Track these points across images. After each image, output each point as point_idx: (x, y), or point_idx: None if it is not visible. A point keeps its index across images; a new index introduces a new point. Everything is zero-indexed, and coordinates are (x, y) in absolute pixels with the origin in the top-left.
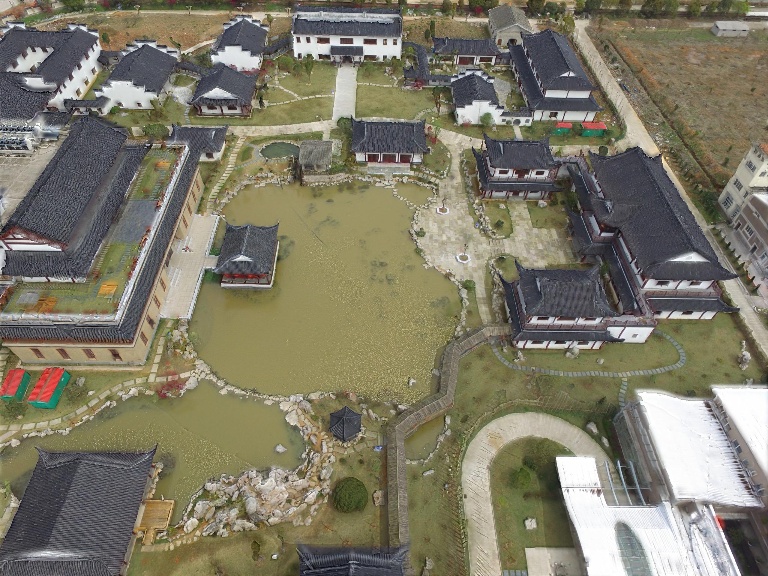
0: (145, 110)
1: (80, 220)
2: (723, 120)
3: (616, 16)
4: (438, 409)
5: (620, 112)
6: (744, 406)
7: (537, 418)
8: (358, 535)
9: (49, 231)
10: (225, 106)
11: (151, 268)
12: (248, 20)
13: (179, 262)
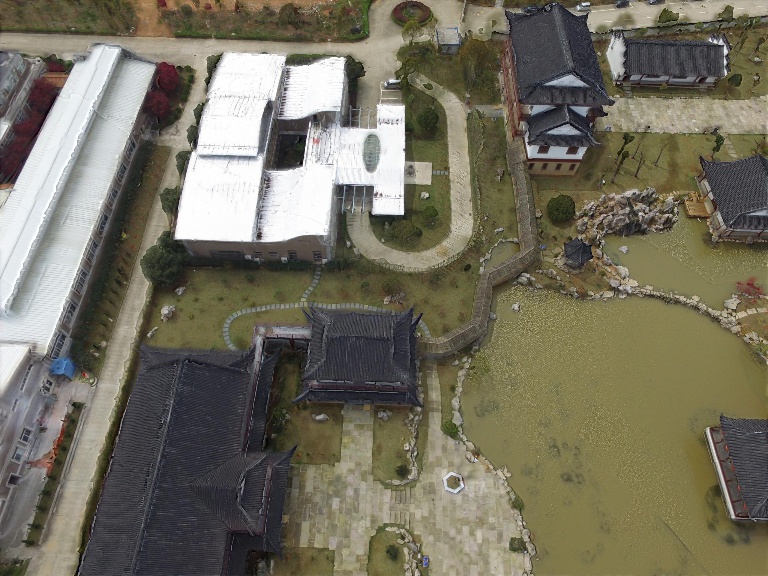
0: None
1: None
2: None
3: None
4: (495, 266)
5: None
6: (236, 221)
7: None
8: (549, 194)
9: None
10: None
11: None
12: None
13: None
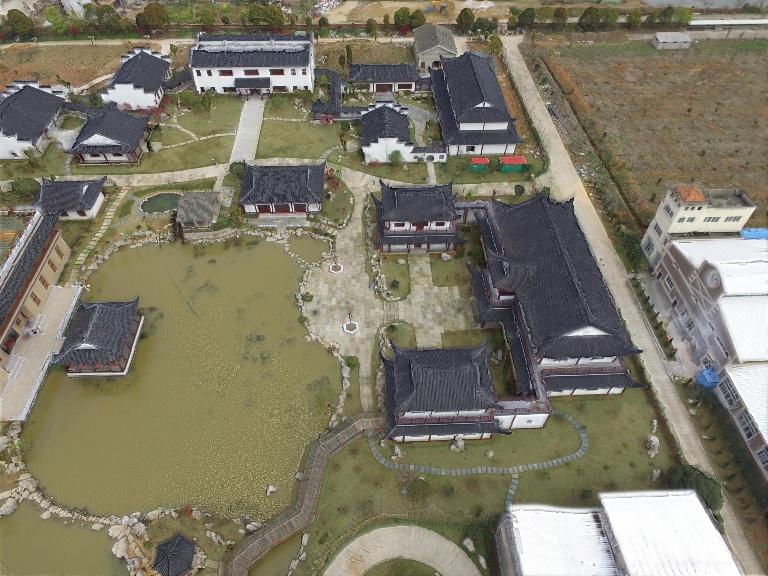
0: (22, 160)
1: None
2: (655, 147)
3: (552, 30)
4: (290, 531)
5: (543, 143)
6: (634, 524)
7: (408, 533)
8: None
9: None
10: (108, 153)
11: None
12: (147, 52)
13: (25, 347)
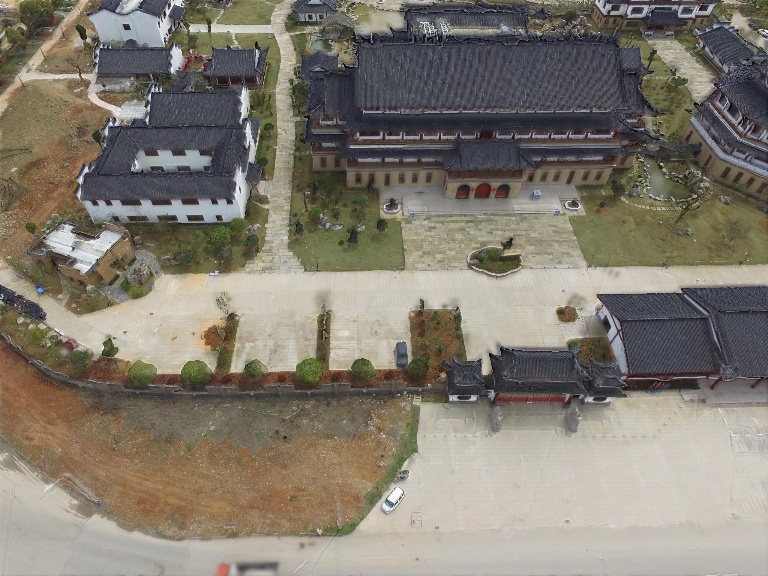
0: (249, 113)
1: None
2: None
3: None
4: None
5: None
6: None
7: None
8: None
9: None
10: None
11: None
12: None
13: None
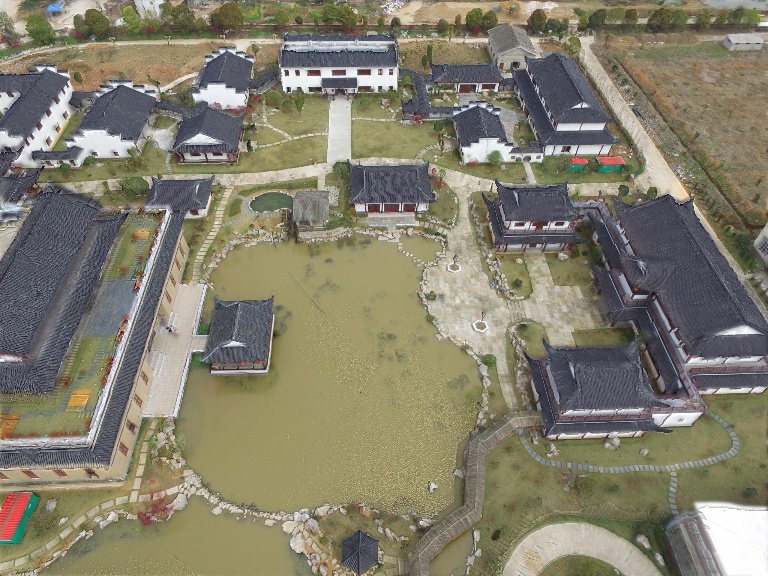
0: (122, 159)
1: (44, 318)
2: (747, 147)
3: (622, 31)
4: (466, 527)
5: (637, 143)
6: None
7: (579, 530)
8: None
9: (5, 342)
10: (209, 152)
11: (129, 366)
12: (232, 52)
13: (163, 345)
